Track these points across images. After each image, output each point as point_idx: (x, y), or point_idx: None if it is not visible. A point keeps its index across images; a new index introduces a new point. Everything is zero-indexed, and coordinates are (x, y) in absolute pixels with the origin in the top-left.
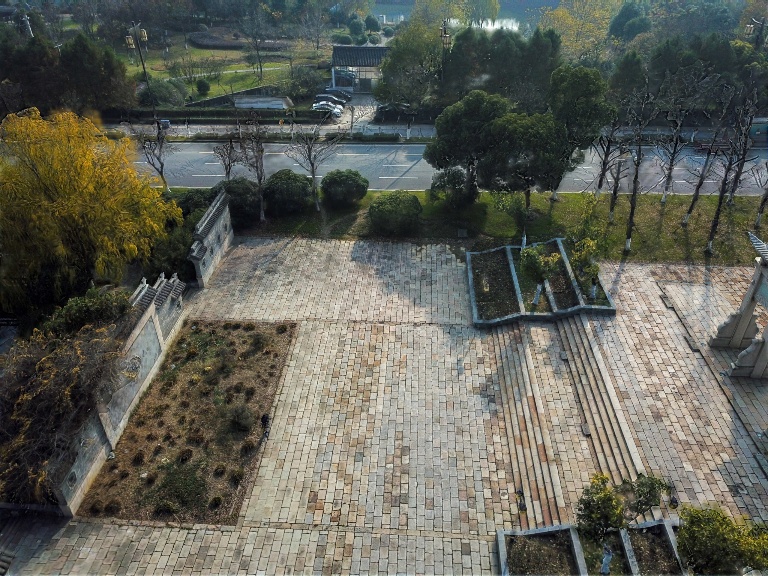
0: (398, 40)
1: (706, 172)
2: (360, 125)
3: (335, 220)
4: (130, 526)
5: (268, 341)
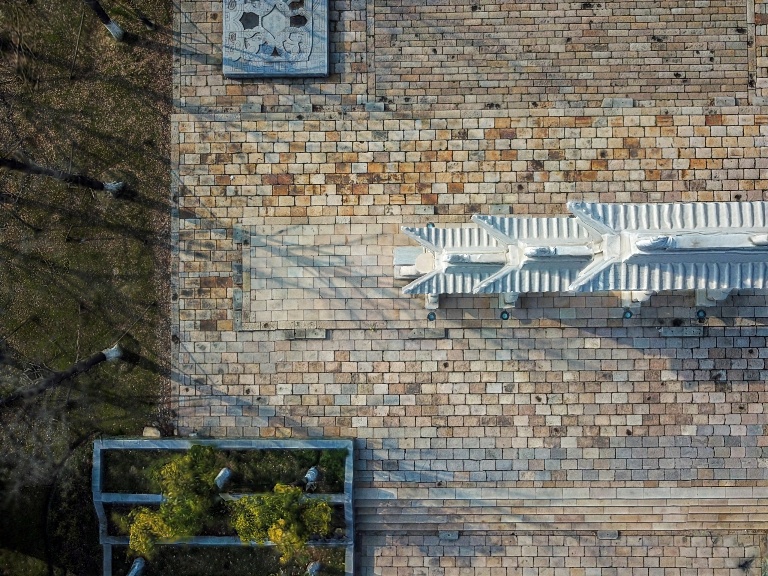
0: None
1: None
2: None
3: None
4: None
5: None
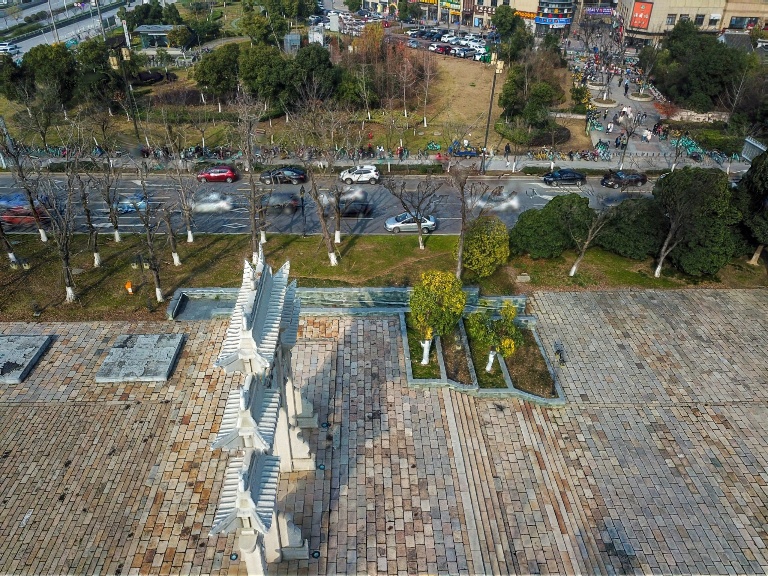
0: None
1: None
2: None
3: None
4: None
5: None
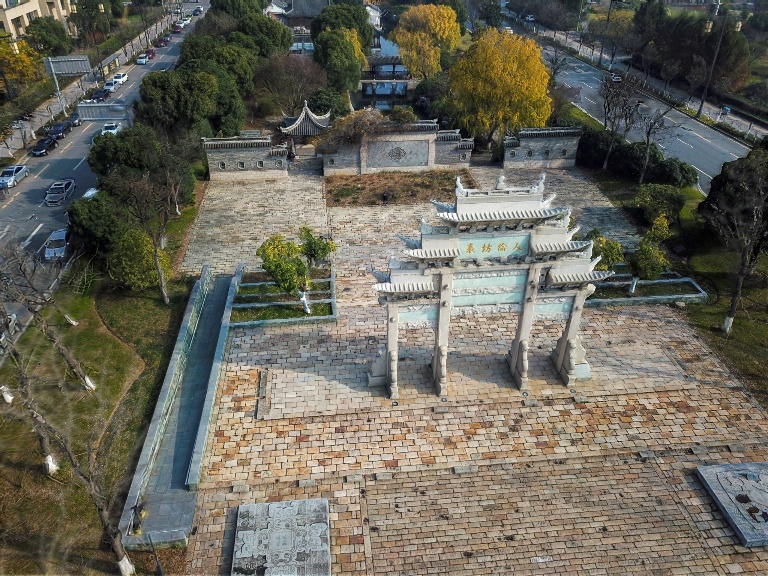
0: None
1: None
2: None
3: (633, 192)
4: (322, 187)
5: None
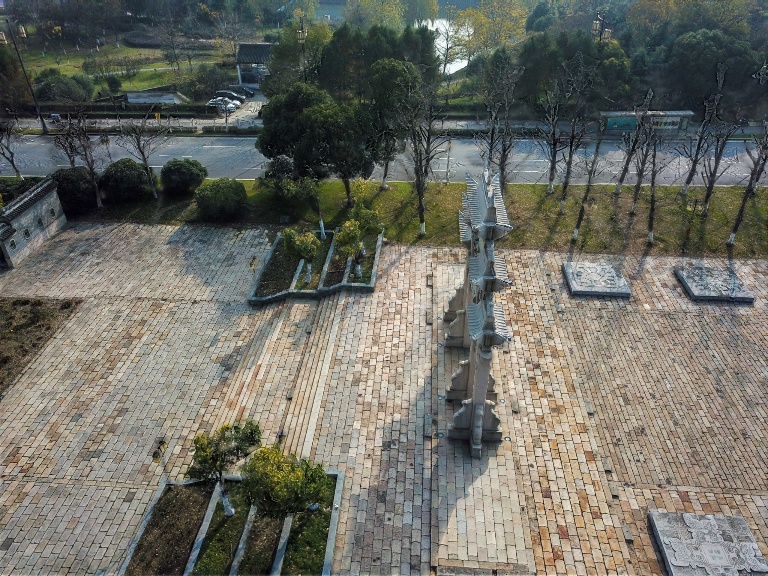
0: (280, 37)
1: (504, 160)
2: (243, 119)
3: (168, 207)
4: None
5: (47, 316)
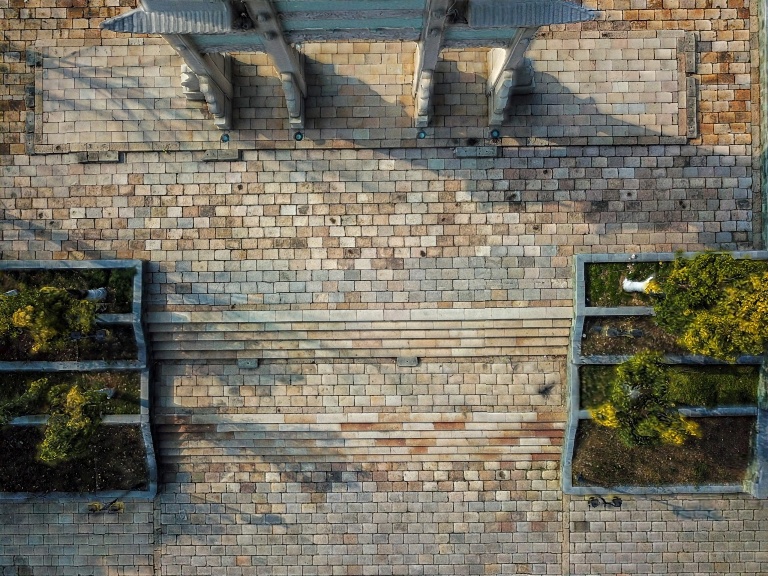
0: None
1: None
2: None
3: None
4: None
5: None
